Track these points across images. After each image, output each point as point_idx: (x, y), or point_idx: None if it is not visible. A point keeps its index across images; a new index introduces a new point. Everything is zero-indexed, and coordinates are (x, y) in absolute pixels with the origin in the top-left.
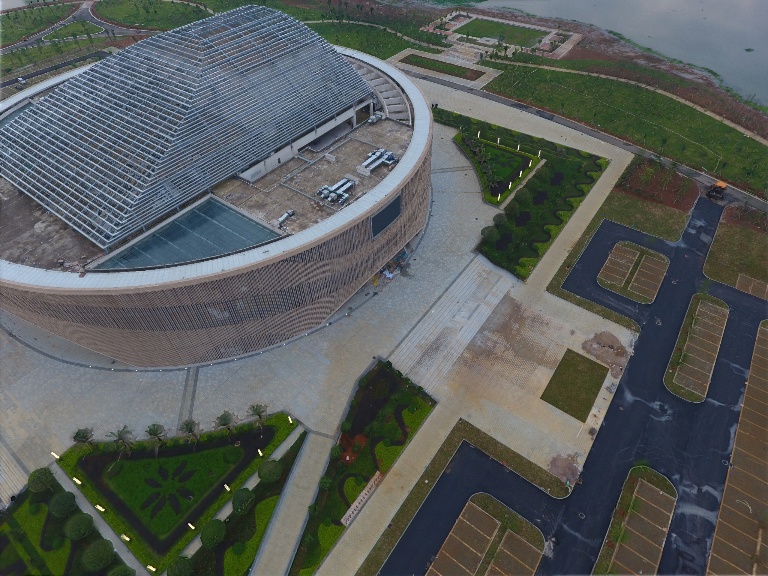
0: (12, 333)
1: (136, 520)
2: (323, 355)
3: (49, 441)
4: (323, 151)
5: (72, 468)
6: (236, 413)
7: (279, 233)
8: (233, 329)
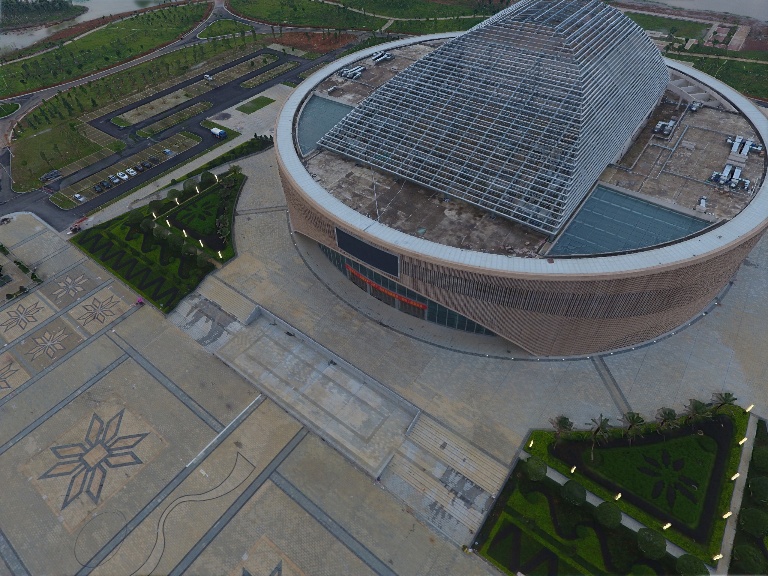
0: (383, 323)
1: (655, 509)
2: (722, 344)
3: (499, 430)
4: (670, 139)
5: (548, 457)
6: (674, 402)
7: (706, 219)
8: (655, 317)
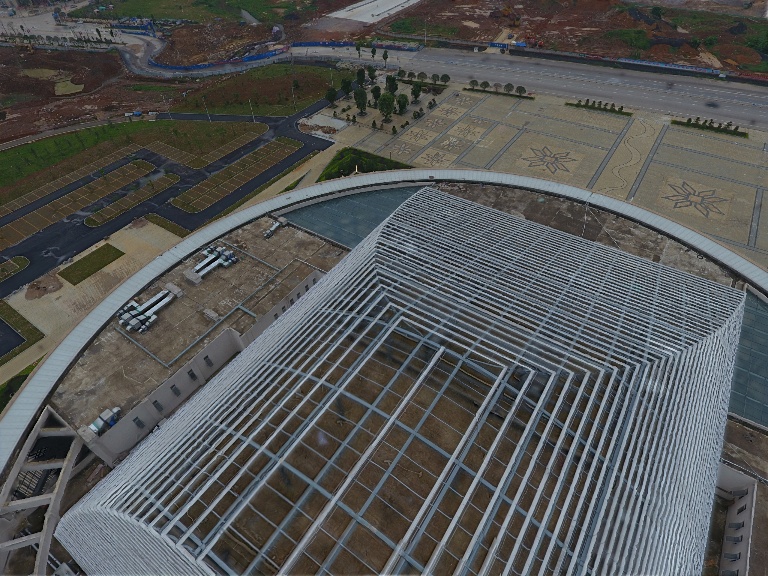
0: None
1: None
2: None
3: None
4: None
5: None
6: None
7: None
8: None
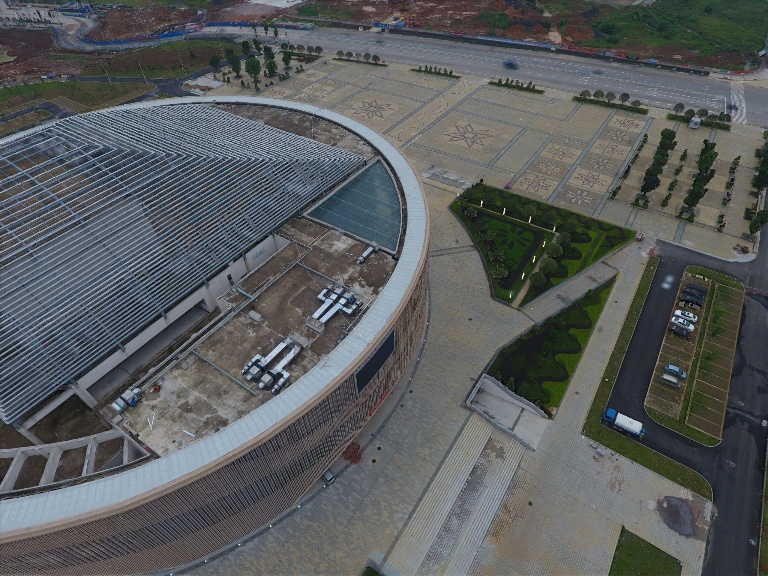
0: None
1: None
2: None
3: None
4: None
5: None
6: None
7: None
8: None
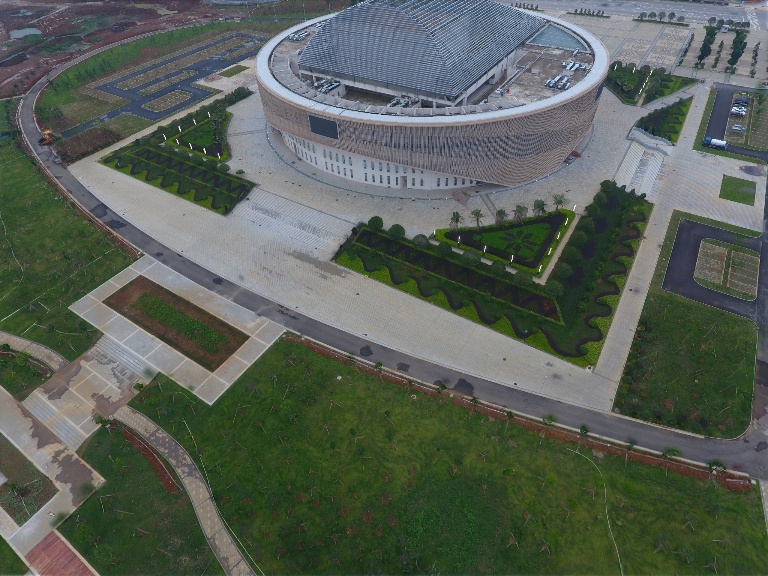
0: None
1: None
2: None
3: None
4: None
5: None
6: None
7: None
8: None
